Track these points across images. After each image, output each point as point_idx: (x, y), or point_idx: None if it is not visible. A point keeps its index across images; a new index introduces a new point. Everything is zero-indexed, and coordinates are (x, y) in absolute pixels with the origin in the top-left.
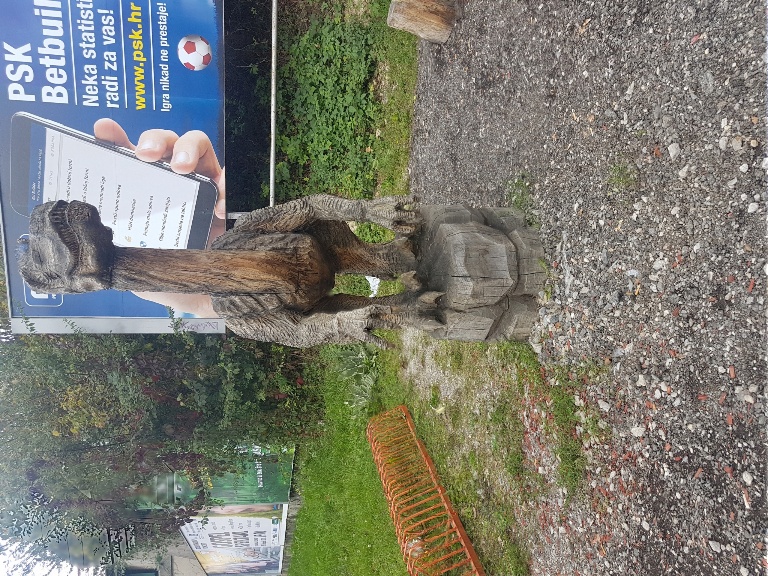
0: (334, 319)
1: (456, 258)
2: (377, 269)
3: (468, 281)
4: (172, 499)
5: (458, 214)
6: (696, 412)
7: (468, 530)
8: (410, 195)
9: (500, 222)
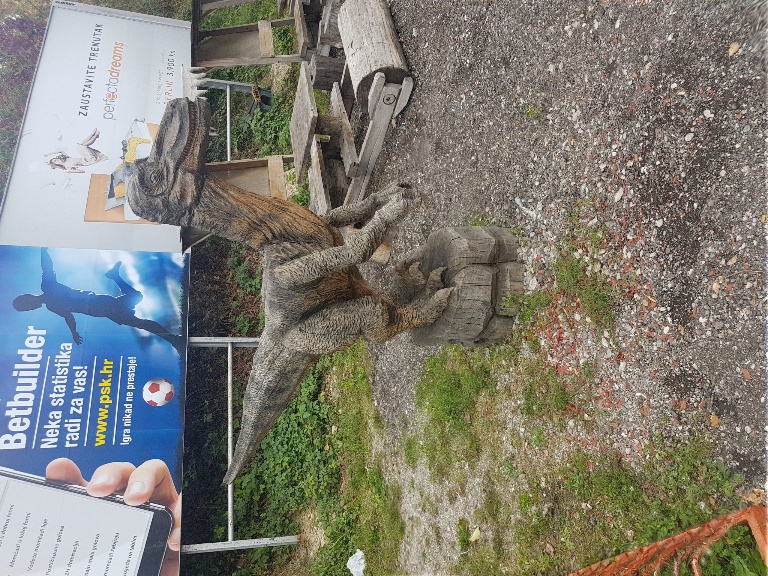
0: None
1: (448, 231)
2: None
3: (462, 239)
4: None
5: None
6: None
7: None
8: None
9: None
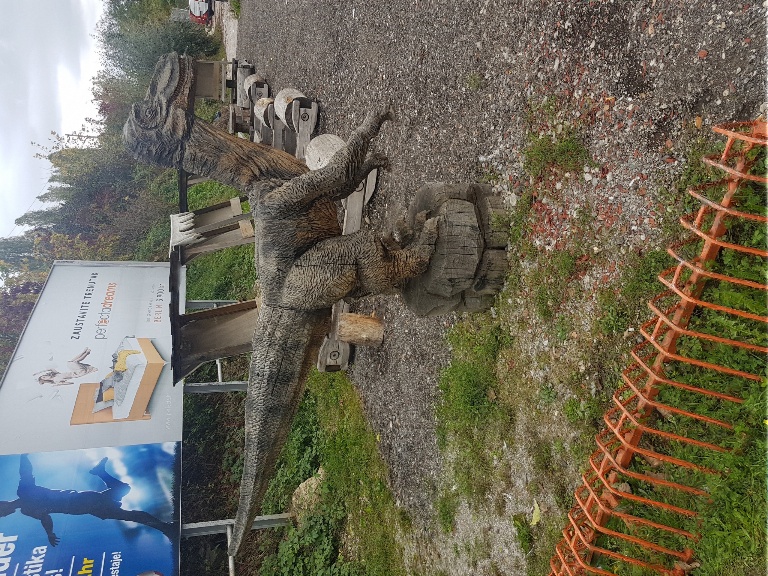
0: None
1: None
2: None
3: None
4: None
5: None
6: None
7: None
8: None
9: None
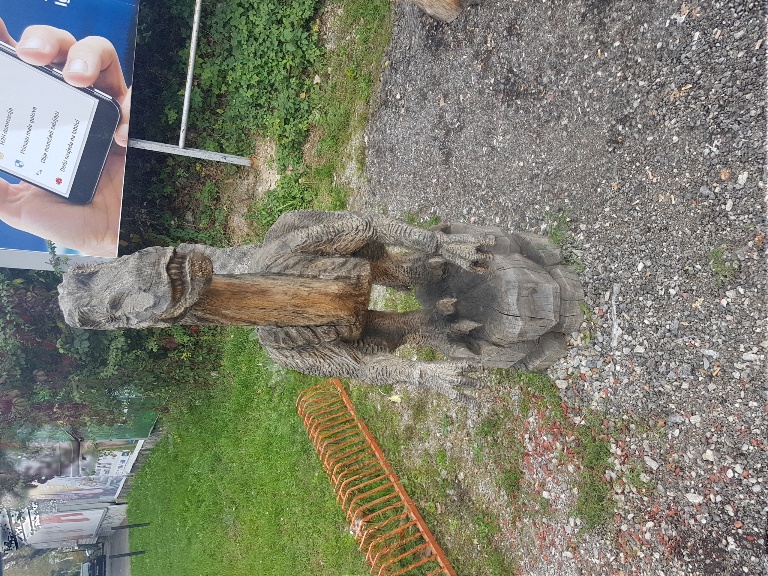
0: (415, 369)
1: (509, 296)
2: (397, 281)
3: (518, 321)
4: (77, 470)
5: (498, 241)
6: None
7: (430, 524)
8: (491, 237)
9: (538, 255)
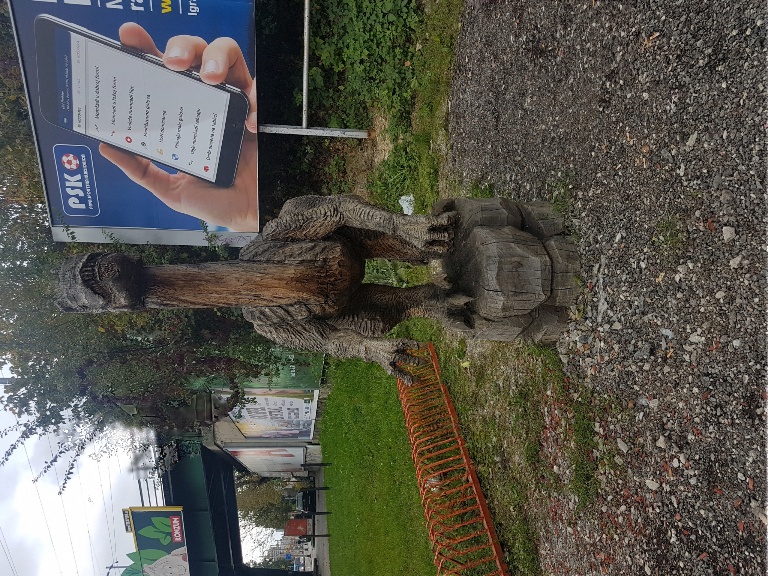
0: (361, 345)
1: (488, 271)
2: (408, 256)
3: (499, 296)
4: (210, 417)
5: (494, 214)
6: (710, 501)
7: (483, 487)
8: (444, 216)
9: (538, 226)
